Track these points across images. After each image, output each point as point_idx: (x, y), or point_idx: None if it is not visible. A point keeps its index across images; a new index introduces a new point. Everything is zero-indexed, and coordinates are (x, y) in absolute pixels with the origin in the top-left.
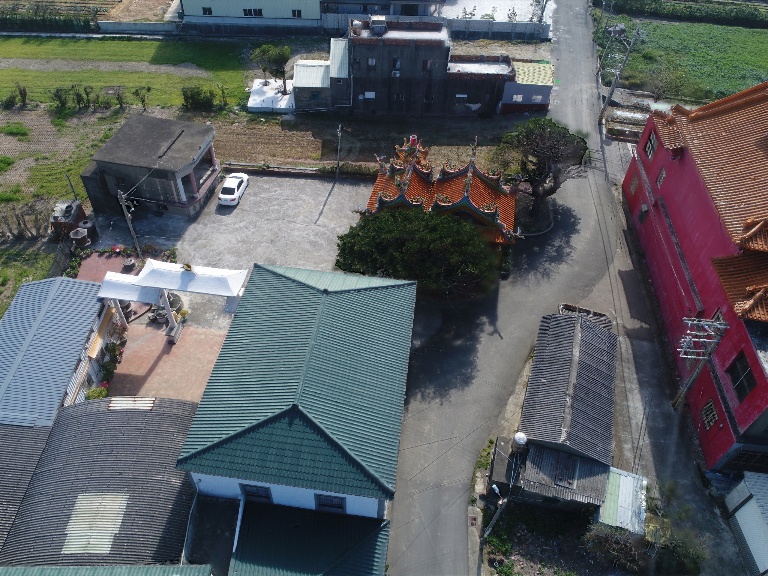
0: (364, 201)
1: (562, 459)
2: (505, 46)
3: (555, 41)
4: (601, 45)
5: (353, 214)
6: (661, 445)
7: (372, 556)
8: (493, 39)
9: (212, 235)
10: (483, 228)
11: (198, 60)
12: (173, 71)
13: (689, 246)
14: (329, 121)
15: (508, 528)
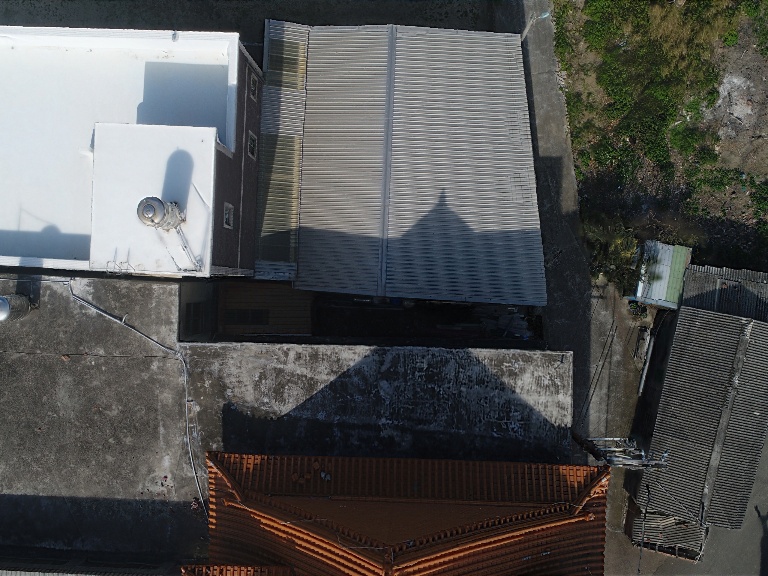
0: None
1: (735, 310)
2: None
3: None
4: None
5: None
6: (578, 363)
7: None
8: None
9: None
10: None
11: None
12: None
13: None
14: None
15: (764, 247)
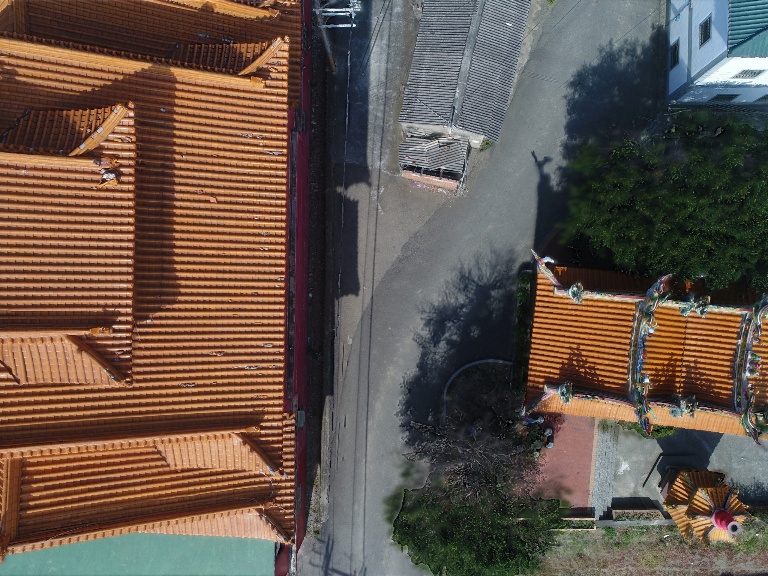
0: None
1: None
2: None
3: None
4: None
5: None
6: (360, 15)
7: None
8: None
9: None
10: (590, 287)
11: None
12: None
13: None
14: None
15: None
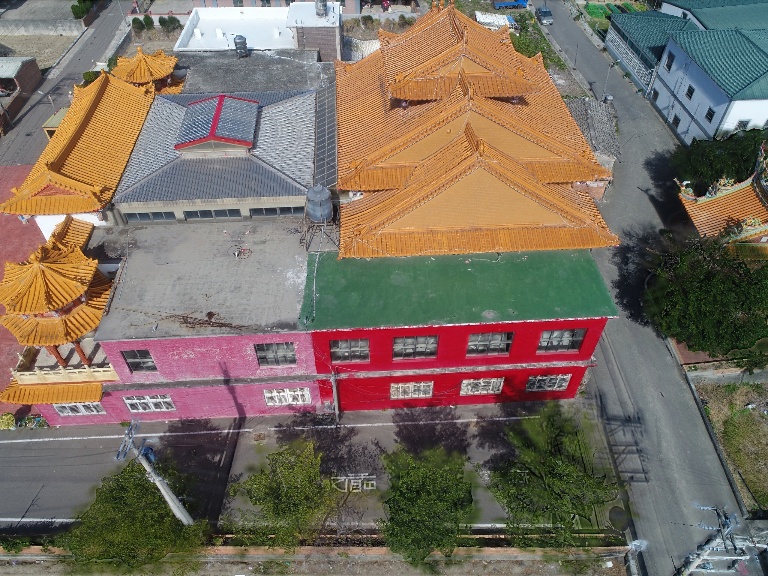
0: None
1: None
2: None
3: None
4: None
5: None
6: None
7: (656, 55)
8: None
9: None
10: None
11: None
12: None
13: None
14: None
15: None
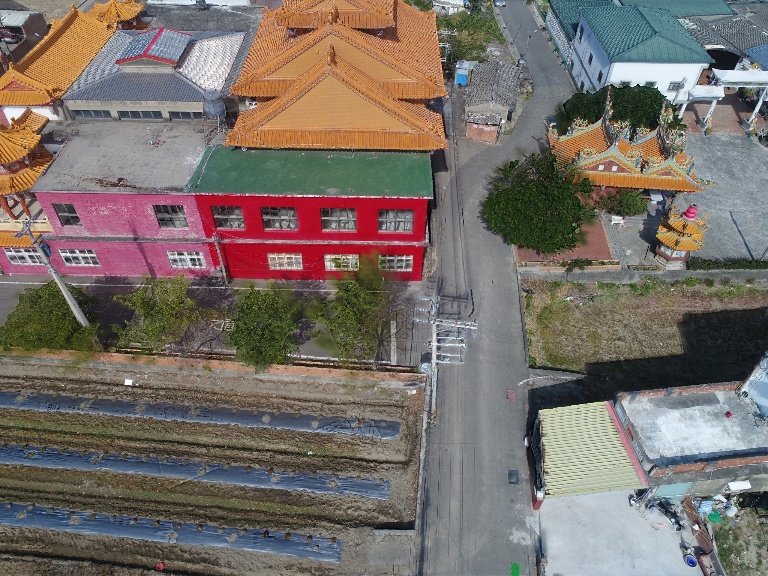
0: (704, 239)
1: None
2: None
3: None
4: None
5: None
6: None
7: (575, 30)
8: None
9: None
10: None
11: None
12: None
13: None
14: None
15: None
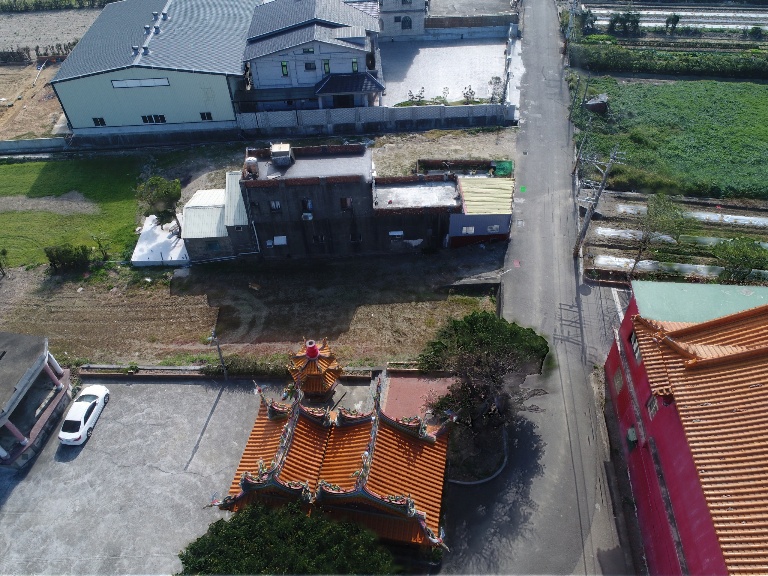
0: None
1: None
2: (460, 137)
3: (522, 125)
4: (579, 125)
5: (239, 447)
6: None
7: None
8: (447, 126)
9: (42, 503)
10: (393, 519)
11: (86, 187)
12: (53, 207)
13: (696, 567)
14: (232, 275)
15: None
